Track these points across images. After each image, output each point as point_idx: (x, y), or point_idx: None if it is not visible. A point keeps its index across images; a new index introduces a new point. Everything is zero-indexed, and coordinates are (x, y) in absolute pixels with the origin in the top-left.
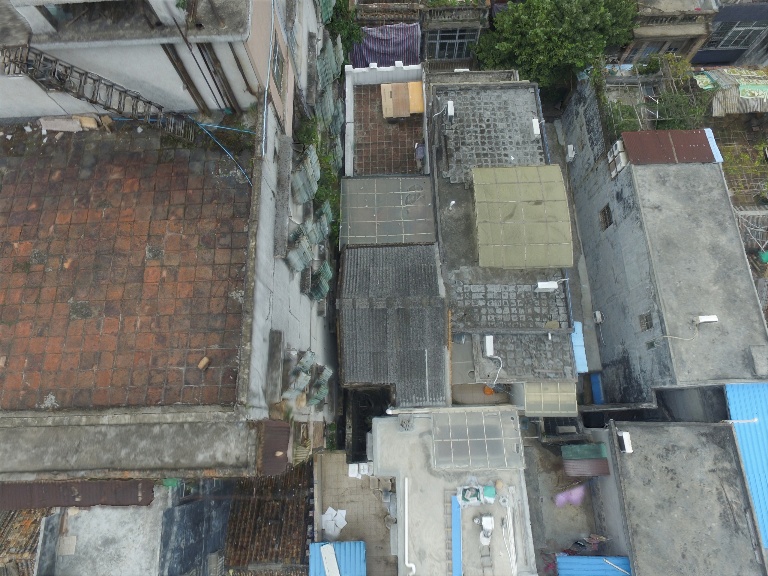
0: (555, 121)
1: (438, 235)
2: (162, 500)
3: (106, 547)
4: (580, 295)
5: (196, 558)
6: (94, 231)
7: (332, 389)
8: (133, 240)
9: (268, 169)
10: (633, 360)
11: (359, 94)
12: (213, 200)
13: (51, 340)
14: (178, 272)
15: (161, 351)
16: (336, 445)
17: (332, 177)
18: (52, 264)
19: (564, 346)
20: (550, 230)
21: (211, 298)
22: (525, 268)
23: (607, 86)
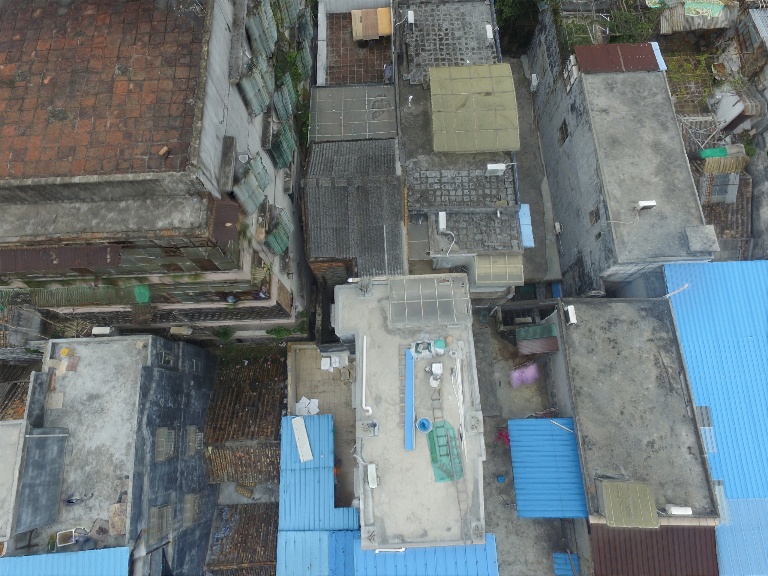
0: (522, 57)
1: (397, 128)
2: (142, 362)
3: (91, 402)
4: (543, 213)
5: (175, 422)
6: (70, 55)
7: (301, 274)
8: (104, 61)
9: (222, 0)
10: (585, 257)
11: (332, 22)
12: (175, 29)
13: (32, 138)
14: (143, 85)
15: (127, 145)
16: (308, 337)
17: (298, 72)
18: (34, 81)
19: (512, 223)
20: (498, 117)
21: (172, 104)
22: (476, 152)
23: (566, 14)
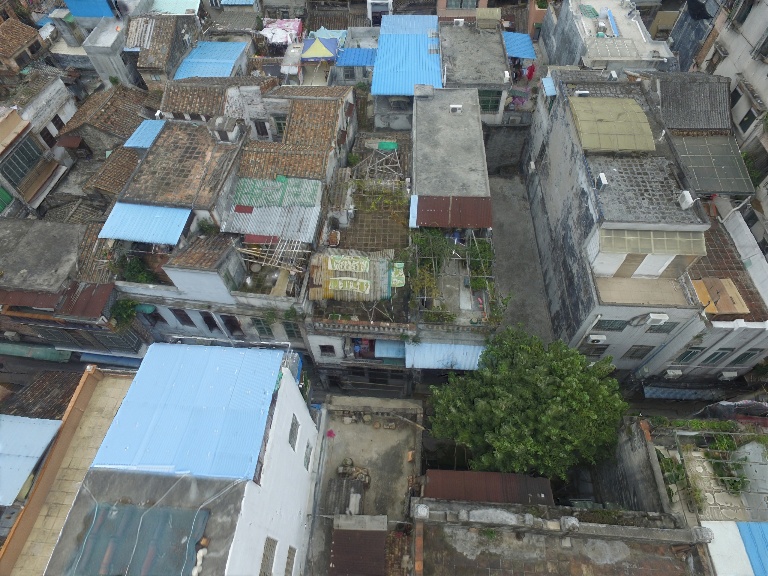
0: None
1: None
2: None
3: None
4: None
5: None
6: None
7: None
8: None
9: None
10: None
11: None
12: None
13: None
14: None
15: None
16: None
17: None
18: None
19: None
20: (589, 107)
21: None
22: None
23: None
